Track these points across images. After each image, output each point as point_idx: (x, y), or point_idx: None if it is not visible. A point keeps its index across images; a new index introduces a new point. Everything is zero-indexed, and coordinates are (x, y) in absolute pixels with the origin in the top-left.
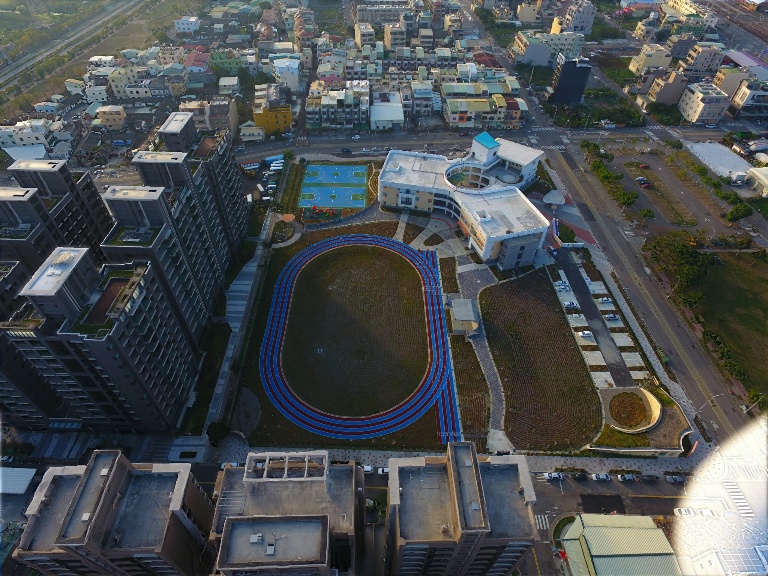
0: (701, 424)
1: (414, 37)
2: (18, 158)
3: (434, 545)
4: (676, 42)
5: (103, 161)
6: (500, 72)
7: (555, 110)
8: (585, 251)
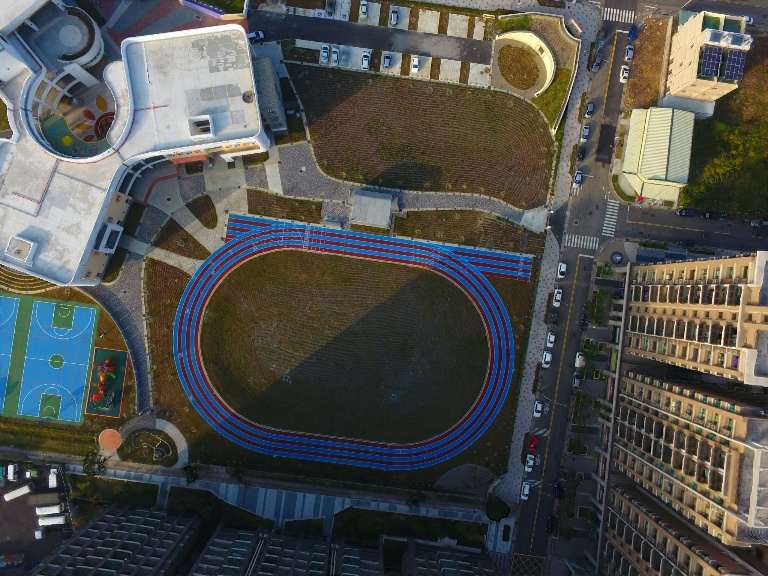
0: (546, 0)
1: None
2: None
3: None
4: None
5: None
6: None
7: None
8: None
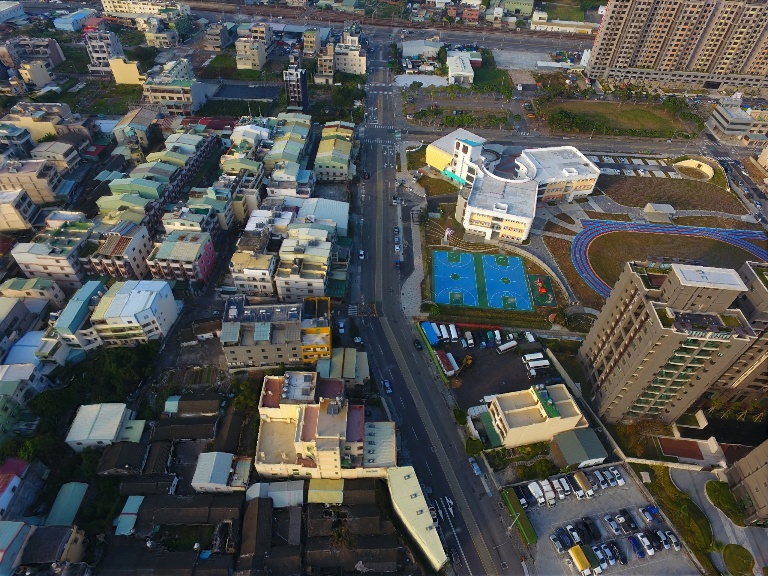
0: None
1: None
2: None
3: None
4: (219, 34)
5: None
6: None
7: None
8: None
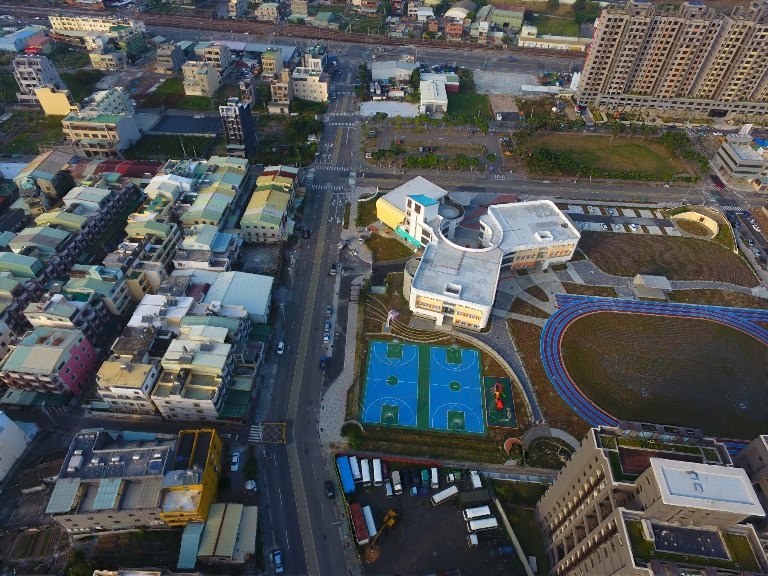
0: None
1: None
2: None
3: None
4: (170, 55)
5: None
6: None
7: (272, 158)
8: None
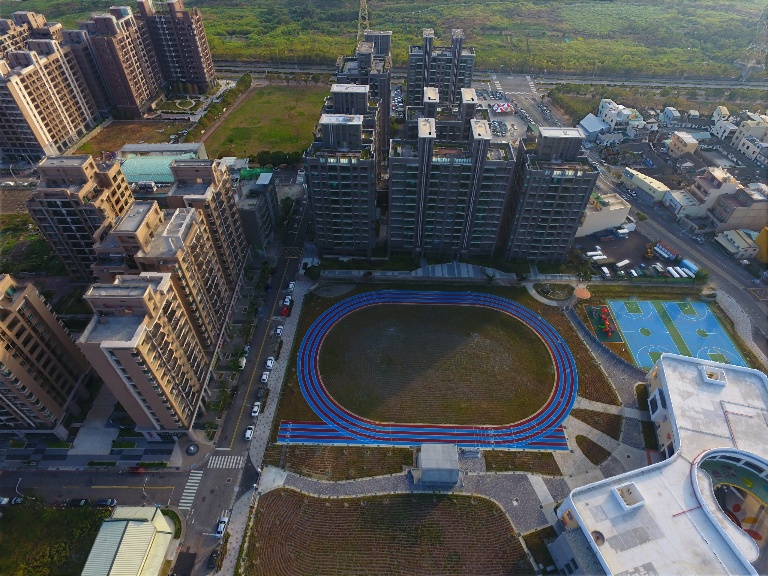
0: None
1: None
2: (582, 123)
3: None
4: None
5: (613, 162)
6: None
7: None
8: None
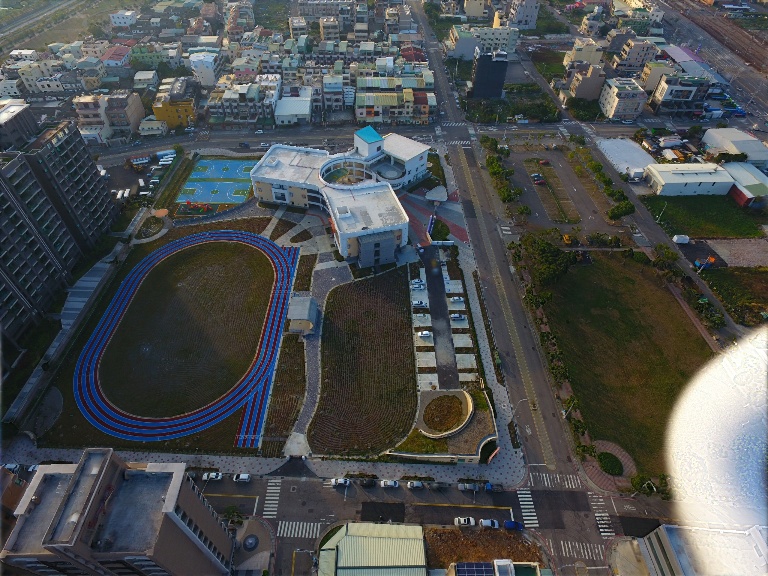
0: (514, 429)
1: (351, 31)
2: None
3: (43, 559)
4: (615, 36)
5: None
6: (421, 66)
7: (472, 105)
8: (454, 249)
